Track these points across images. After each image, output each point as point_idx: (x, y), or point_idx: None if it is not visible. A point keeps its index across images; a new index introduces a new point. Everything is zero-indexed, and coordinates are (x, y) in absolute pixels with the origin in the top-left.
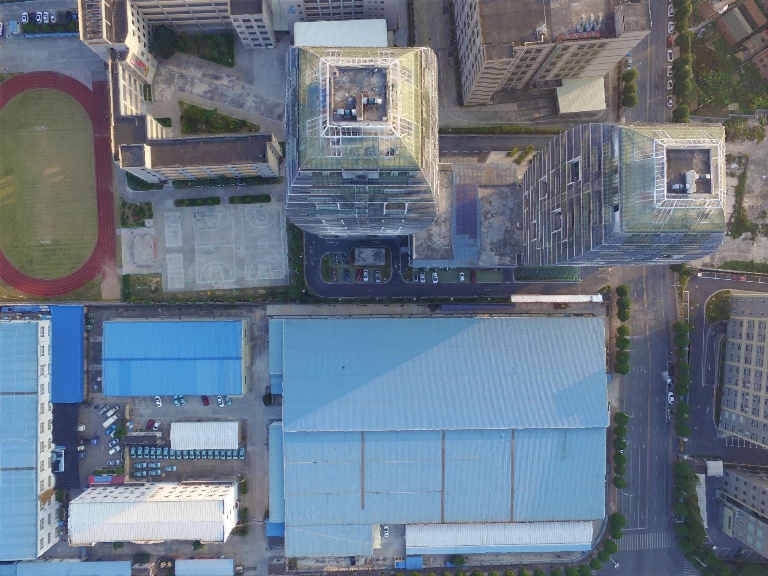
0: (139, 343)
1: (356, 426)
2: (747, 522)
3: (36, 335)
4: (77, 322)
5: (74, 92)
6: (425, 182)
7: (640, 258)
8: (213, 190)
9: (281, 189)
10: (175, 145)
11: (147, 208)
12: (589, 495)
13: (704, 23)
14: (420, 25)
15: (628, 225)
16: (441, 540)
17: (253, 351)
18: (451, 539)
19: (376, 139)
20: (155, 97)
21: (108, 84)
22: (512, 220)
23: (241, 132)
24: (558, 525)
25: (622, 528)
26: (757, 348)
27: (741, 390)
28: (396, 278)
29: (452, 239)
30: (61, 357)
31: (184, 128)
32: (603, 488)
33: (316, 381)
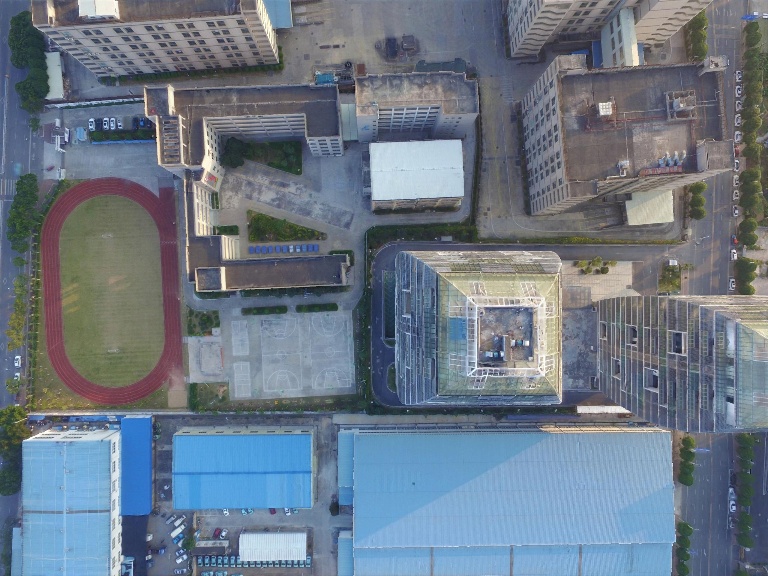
0: (209, 457)
1: (426, 543)
2: None
3: (109, 453)
4: (146, 434)
5: (141, 199)
6: (557, 400)
7: None
8: (280, 298)
9: (348, 297)
10: (250, 265)
11: (214, 317)
12: None
13: None
14: (488, 133)
15: (744, 422)
16: None
17: (319, 459)
18: None
19: (521, 377)
20: (222, 204)
21: (175, 191)
22: (586, 343)
23: (308, 240)
24: None
25: None
26: None
27: None
28: None
29: None
30: (130, 470)
31: (252, 238)
32: None
33: (387, 497)
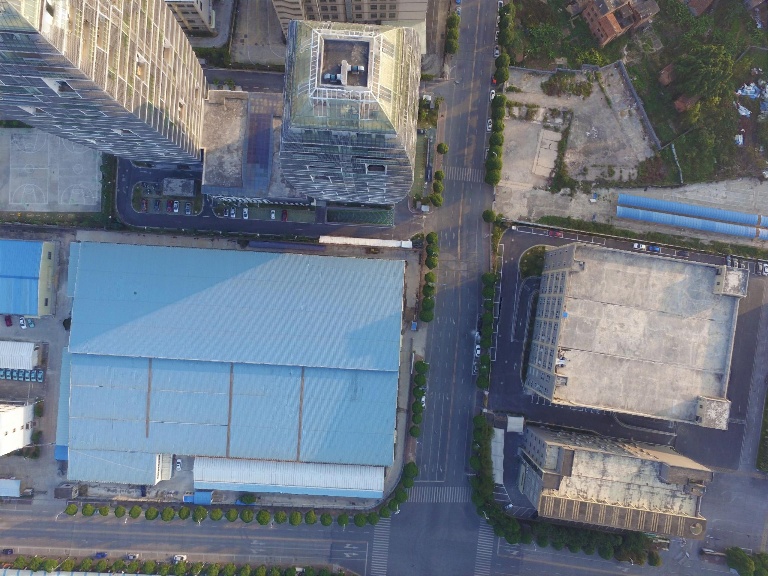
0: None
1: (142, 352)
2: (532, 477)
3: None
4: None
5: None
6: (55, 50)
7: (349, 169)
8: None
9: None
10: None
11: None
12: (378, 440)
13: None
14: None
15: None
16: (229, 476)
17: (60, 275)
18: (239, 476)
19: None
20: None
21: None
22: None
23: None
24: (349, 470)
25: (420, 479)
26: (552, 300)
27: (540, 344)
28: (207, 212)
29: (243, 168)
30: None
31: None
32: (393, 434)
33: (107, 305)
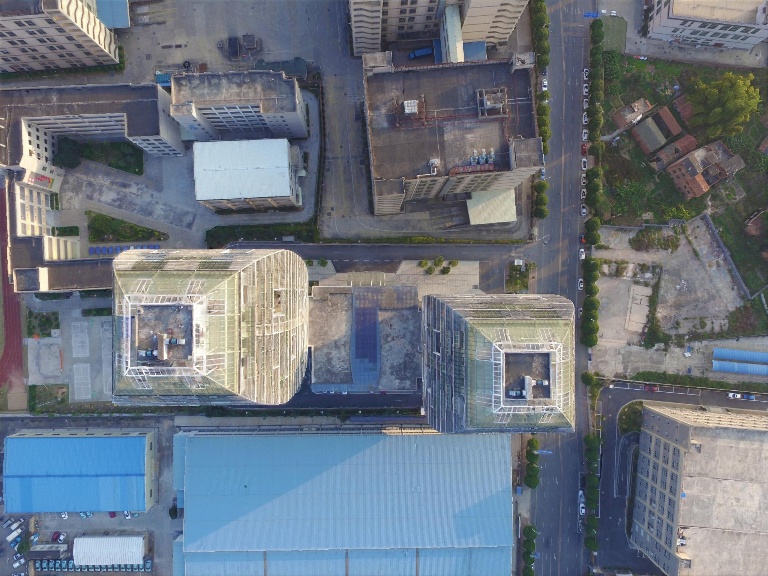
0: (41, 459)
1: (257, 546)
2: None
3: None
4: None
5: None
6: (248, 400)
7: None
8: None
9: None
10: (73, 266)
11: (54, 318)
12: None
13: (619, 131)
14: (332, 132)
15: (472, 422)
16: None
17: (161, 462)
18: None
19: (182, 377)
20: (63, 205)
21: None
22: (413, 343)
23: (150, 241)
24: None
25: None
26: (662, 469)
27: (648, 507)
28: (305, 389)
29: (351, 363)
30: None
31: (90, 239)
32: None
33: (218, 500)
